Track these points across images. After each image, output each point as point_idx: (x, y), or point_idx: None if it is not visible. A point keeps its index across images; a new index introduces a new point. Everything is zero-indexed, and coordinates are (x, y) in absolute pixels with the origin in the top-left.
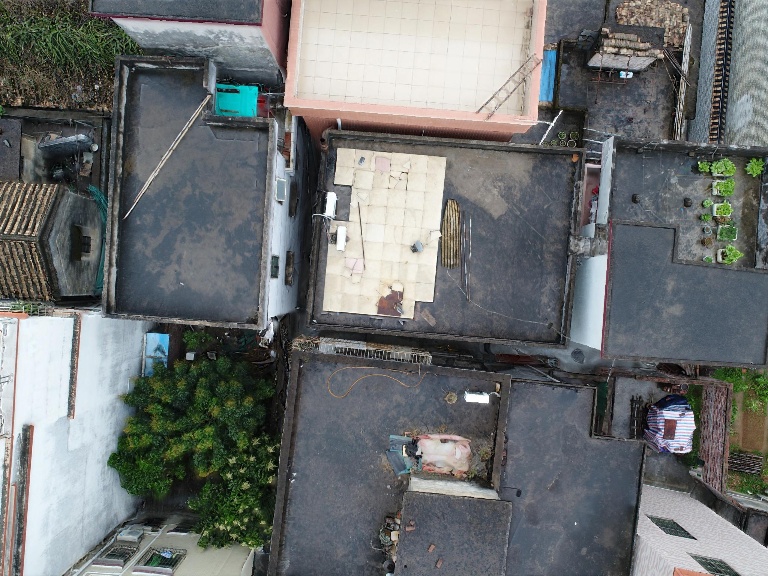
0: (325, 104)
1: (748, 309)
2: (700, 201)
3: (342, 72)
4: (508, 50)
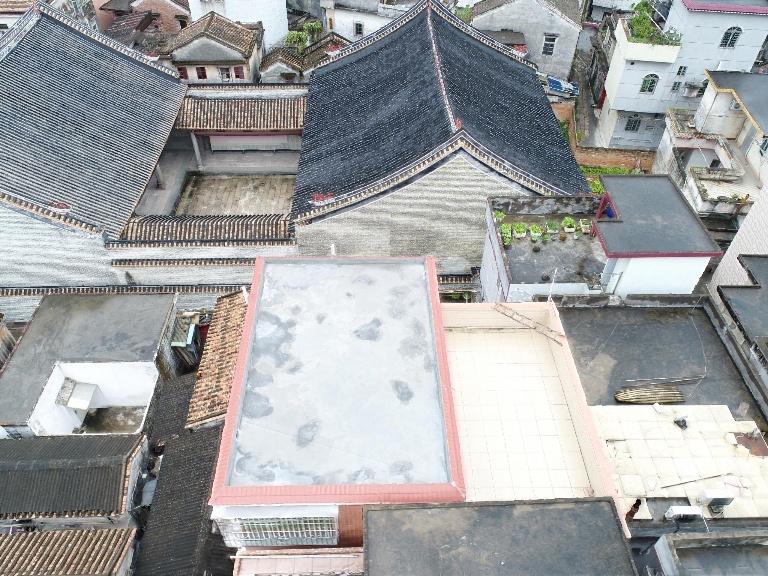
0: (610, 487)
1: (634, 186)
2: (532, 244)
3: (545, 494)
4: (476, 343)
